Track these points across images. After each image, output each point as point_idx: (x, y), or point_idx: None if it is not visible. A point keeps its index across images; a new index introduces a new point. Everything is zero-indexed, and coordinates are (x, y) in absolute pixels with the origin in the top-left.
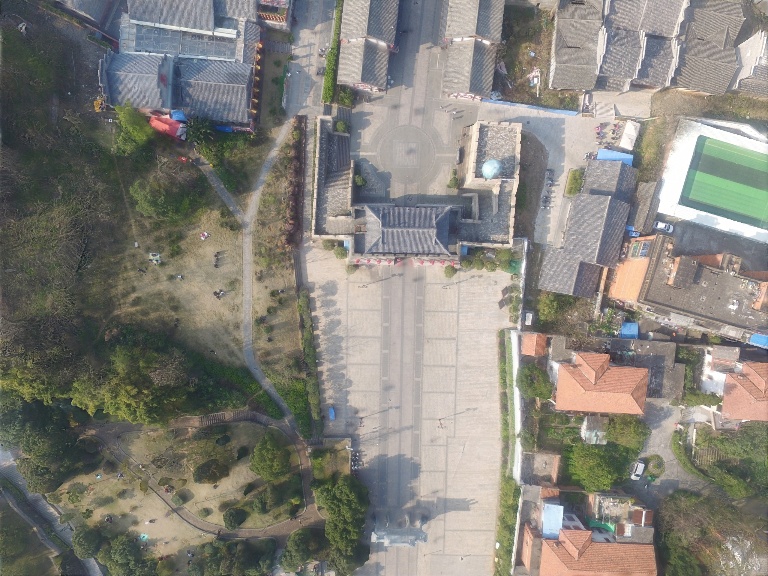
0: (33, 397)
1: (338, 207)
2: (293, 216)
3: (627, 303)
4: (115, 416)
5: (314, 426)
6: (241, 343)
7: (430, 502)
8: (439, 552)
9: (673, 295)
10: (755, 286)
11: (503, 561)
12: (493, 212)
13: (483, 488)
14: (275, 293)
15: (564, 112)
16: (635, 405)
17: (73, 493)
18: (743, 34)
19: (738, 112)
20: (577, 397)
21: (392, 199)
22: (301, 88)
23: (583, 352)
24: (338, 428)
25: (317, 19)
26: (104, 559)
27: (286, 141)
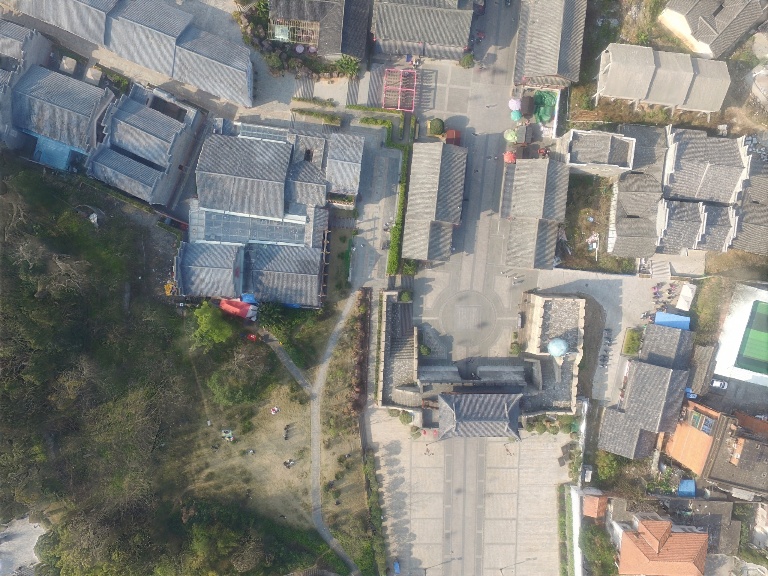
0: None
1: (404, 377)
2: (358, 383)
3: None
4: None
5: None
6: (310, 507)
7: None
8: None
9: (736, 472)
10: None
11: None
12: (556, 380)
13: None
14: (342, 459)
15: None
16: (696, 570)
17: None
18: None
19: None
20: (641, 565)
21: (454, 362)
22: (366, 261)
23: (645, 517)
24: None
25: (381, 193)
26: None
27: (352, 313)
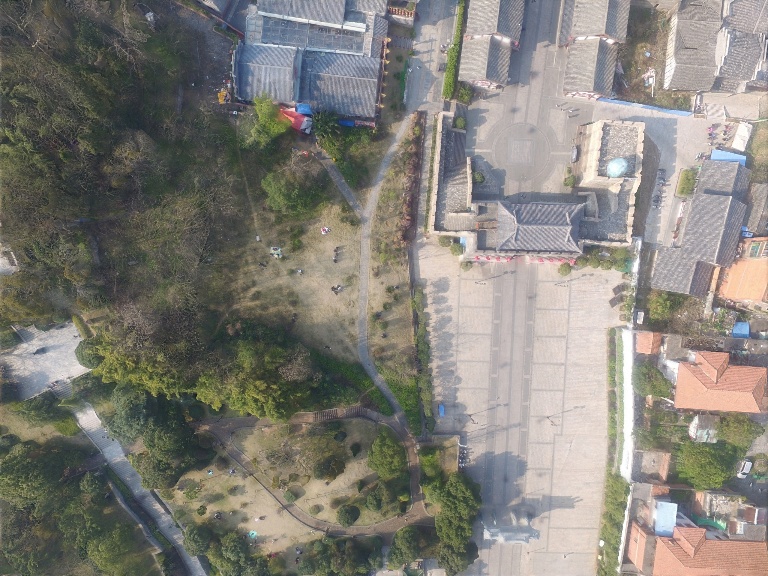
0: (160, 391)
1: (457, 203)
2: (409, 212)
3: (740, 303)
4: (230, 411)
5: (423, 423)
6: (356, 339)
7: (535, 500)
8: (542, 550)
9: None
10: None
11: (609, 559)
12: (611, 211)
13: (588, 486)
14: (391, 289)
15: (677, 112)
16: (754, 404)
17: (190, 489)
18: None
19: None
20: (698, 395)
21: (506, 196)
22: (421, 84)
23: None
24: (446, 425)
25: (439, 15)
26: (215, 556)
27: (406, 136)
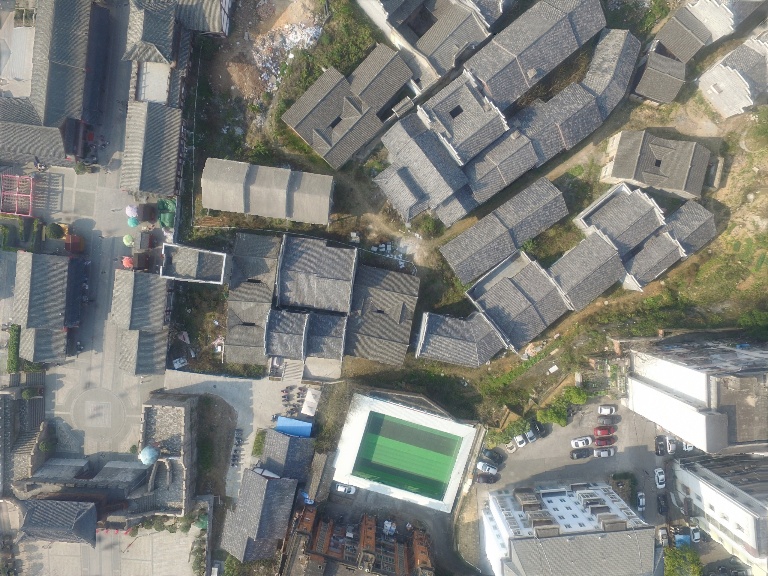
0: None
1: (24, 471)
2: None
3: None
4: None
5: None
6: None
7: None
8: None
9: None
10: None
11: None
12: None
13: None
14: None
15: None
16: None
17: None
18: (433, 298)
19: (432, 370)
20: None
21: (86, 455)
22: None
23: None
24: None
25: (1, 294)
26: None
27: None
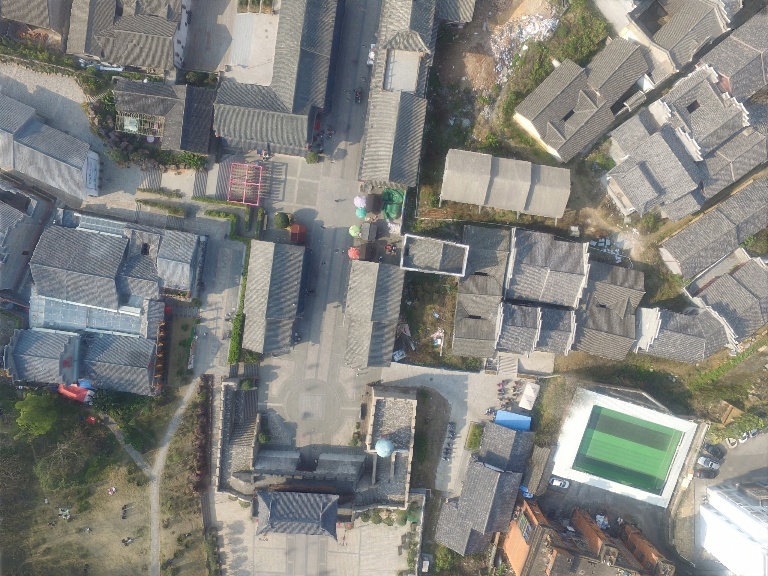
0: None
1: (242, 463)
2: (201, 465)
3: None
4: None
5: None
6: None
7: None
8: None
9: None
10: (631, 575)
11: None
12: (390, 475)
13: None
14: (182, 538)
15: None
16: None
17: None
18: (649, 293)
19: (642, 365)
20: None
21: (298, 448)
22: (208, 349)
23: None
24: None
25: (224, 284)
26: None
27: (193, 399)
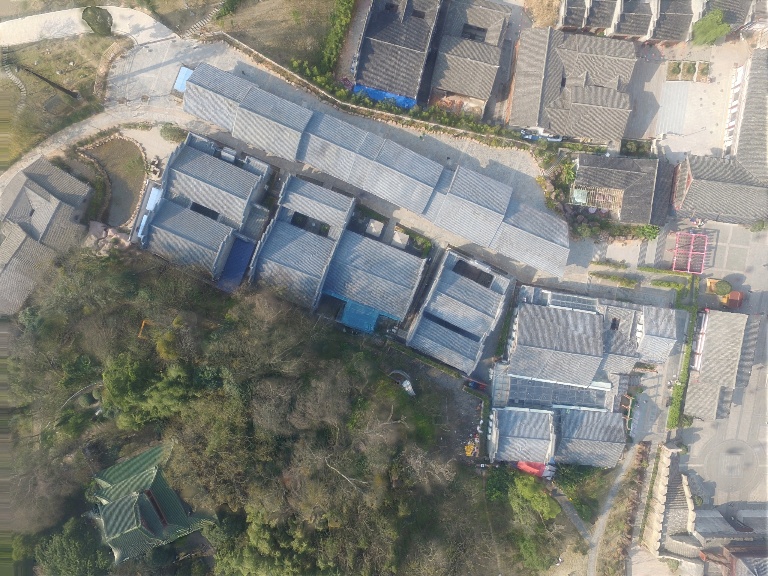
0: None
1: (678, 526)
2: None
3: None
4: None
5: None
6: None
7: None
8: None
9: None
10: None
11: None
12: None
13: None
14: None
15: None
16: None
17: None
18: None
19: None
20: None
21: (715, 506)
22: (647, 416)
23: None
24: None
25: None
26: None
27: (632, 466)
